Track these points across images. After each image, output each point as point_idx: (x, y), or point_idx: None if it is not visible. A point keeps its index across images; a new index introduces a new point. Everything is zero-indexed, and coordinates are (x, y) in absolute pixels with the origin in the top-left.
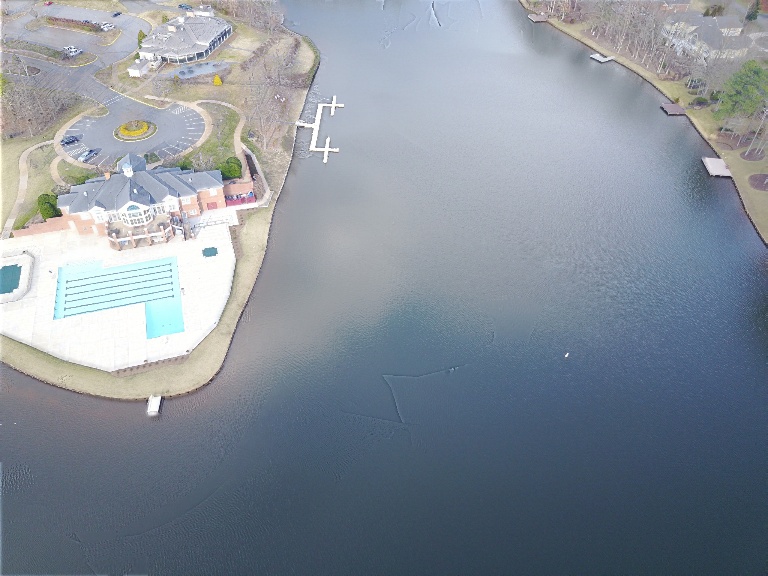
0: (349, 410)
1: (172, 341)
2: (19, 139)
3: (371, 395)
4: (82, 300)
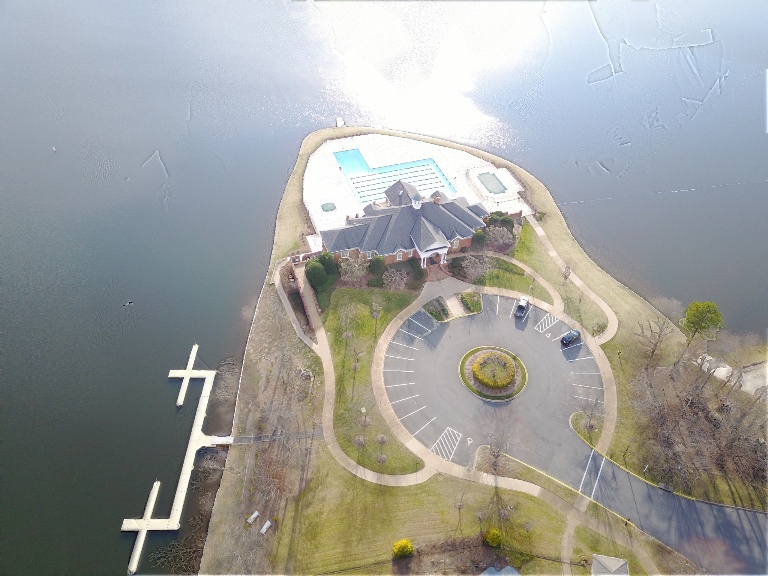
0: (223, 155)
1: (340, 147)
2: (663, 364)
3: (206, 155)
4: (422, 174)
